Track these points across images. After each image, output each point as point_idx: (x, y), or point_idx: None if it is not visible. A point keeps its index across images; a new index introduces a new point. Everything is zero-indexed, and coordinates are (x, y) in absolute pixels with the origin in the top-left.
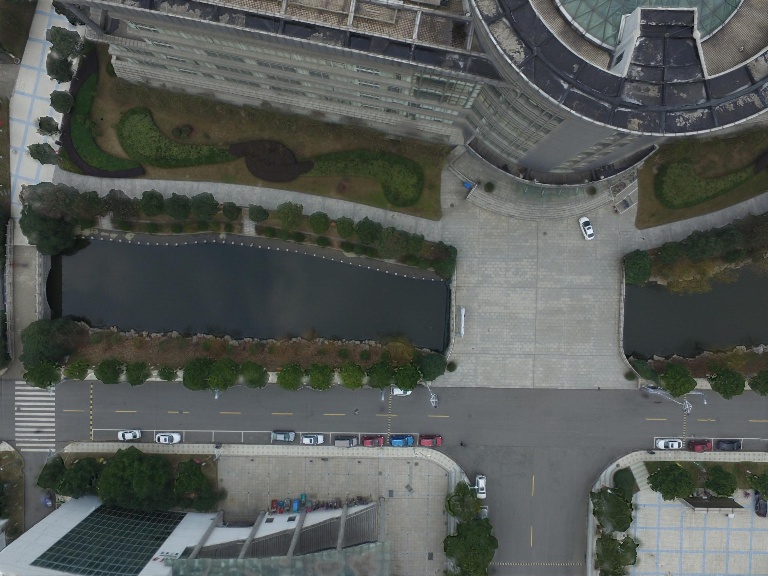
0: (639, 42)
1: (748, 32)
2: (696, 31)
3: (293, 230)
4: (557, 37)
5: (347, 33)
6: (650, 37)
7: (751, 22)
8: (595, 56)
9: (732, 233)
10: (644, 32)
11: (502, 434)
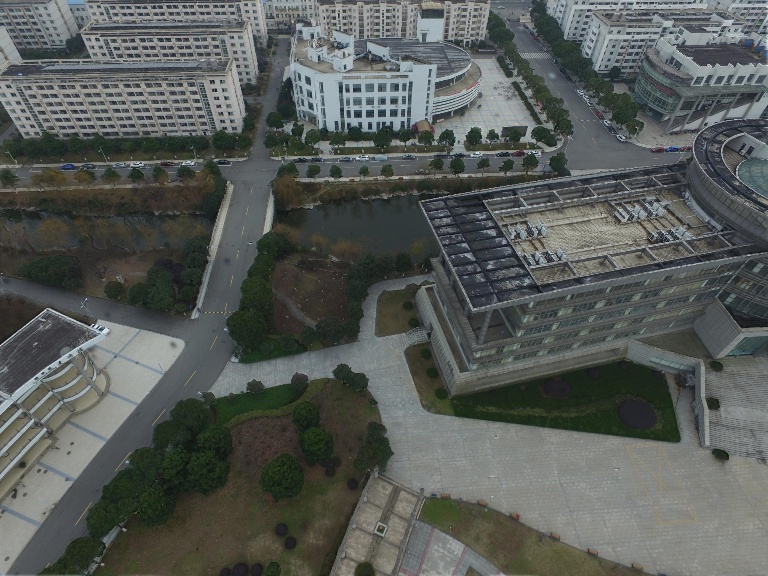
0: None
1: None
2: None
3: None
4: None
5: None
6: None
7: None
8: None
9: None
10: None
11: (622, 154)
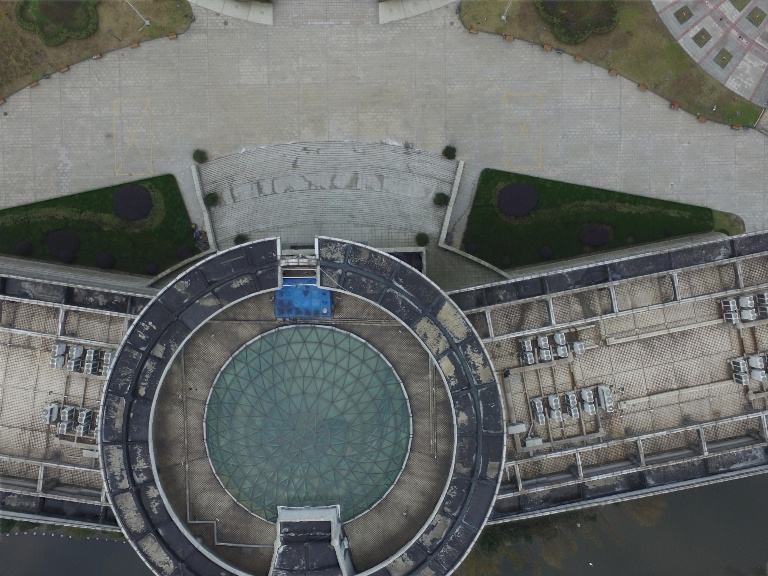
0: (282, 548)
1: (411, 497)
2: (333, 540)
3: (92, 535)
4: (202, 551)
5: (37, 498)
6: (292, 545)
7: (413, 488)
8: (266, 526)
9: (510, 531)
10: (285, 541)
11: None
